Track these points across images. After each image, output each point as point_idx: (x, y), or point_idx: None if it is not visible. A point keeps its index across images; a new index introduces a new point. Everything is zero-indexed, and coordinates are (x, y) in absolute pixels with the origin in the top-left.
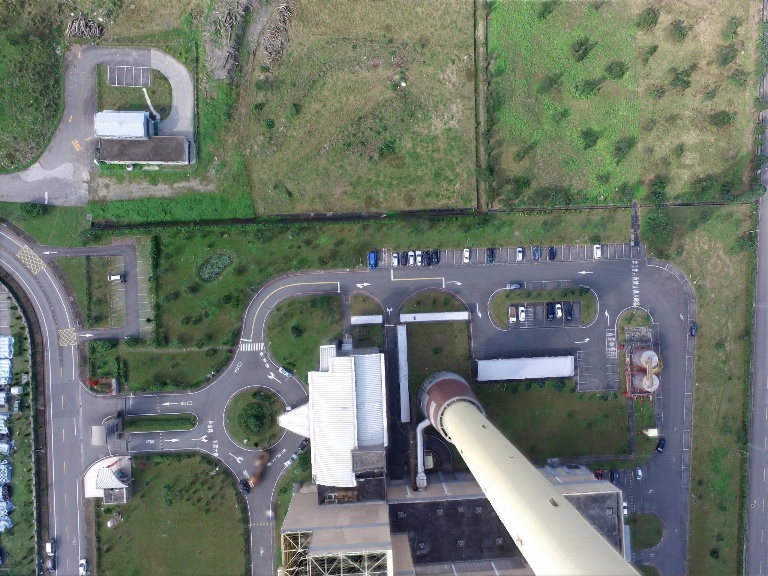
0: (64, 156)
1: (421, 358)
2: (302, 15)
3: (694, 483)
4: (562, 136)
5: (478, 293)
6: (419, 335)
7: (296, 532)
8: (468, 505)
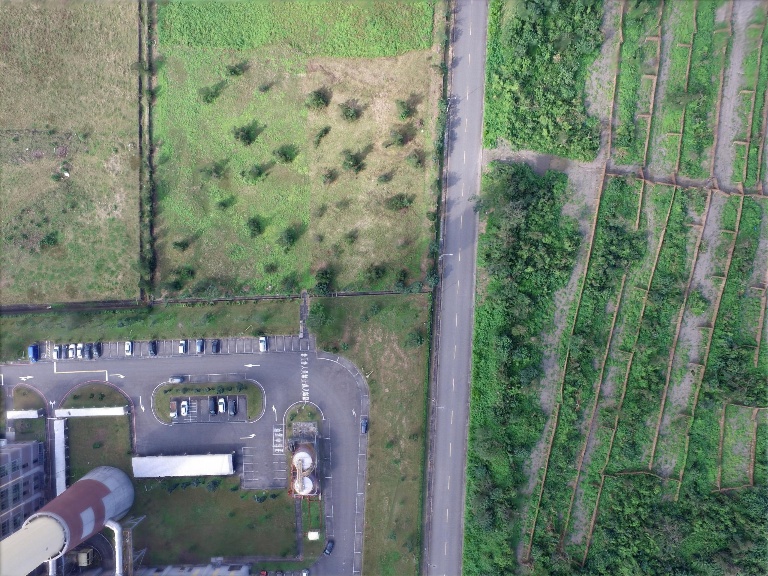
0: None
1: (83, 452)
2: None
3: None
4: (228, 224)
5: (141, 386)
6: (81, 429)
7: None
8: None
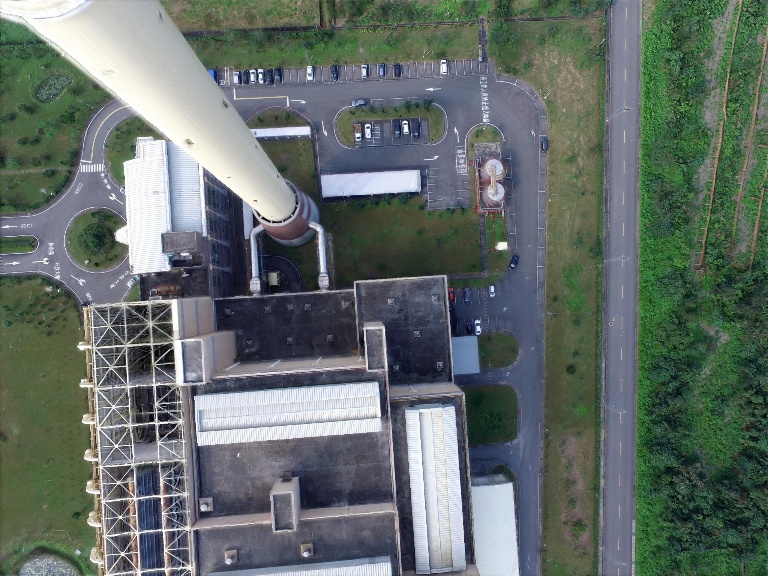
0: None
1: None
2: None
3: (549, 300)
4: None
5: (323, 111)
6: None
7: None
8: (298, 302)
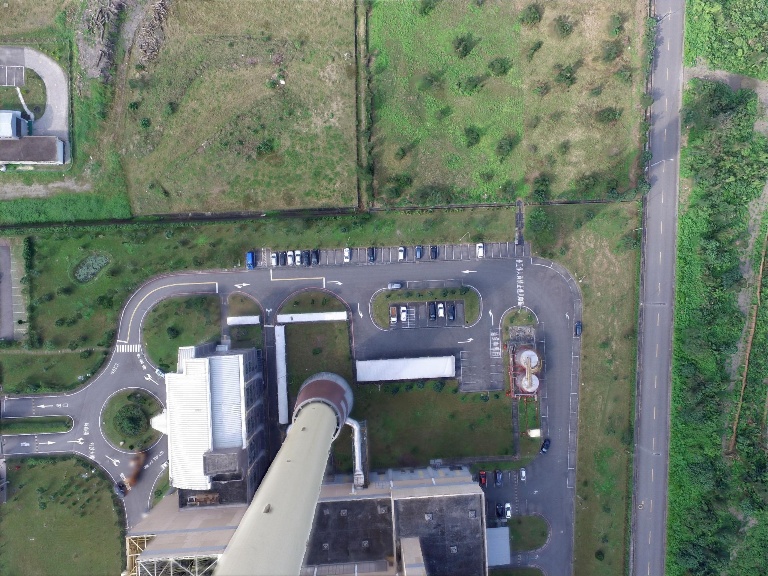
0: None
1: (301, 359)
2: (178, 13)
3: (580, 484)
4: (445, 134)
5: (359, 293)
6: (299, 336)
7: (142, 536)
8: (334, 507)
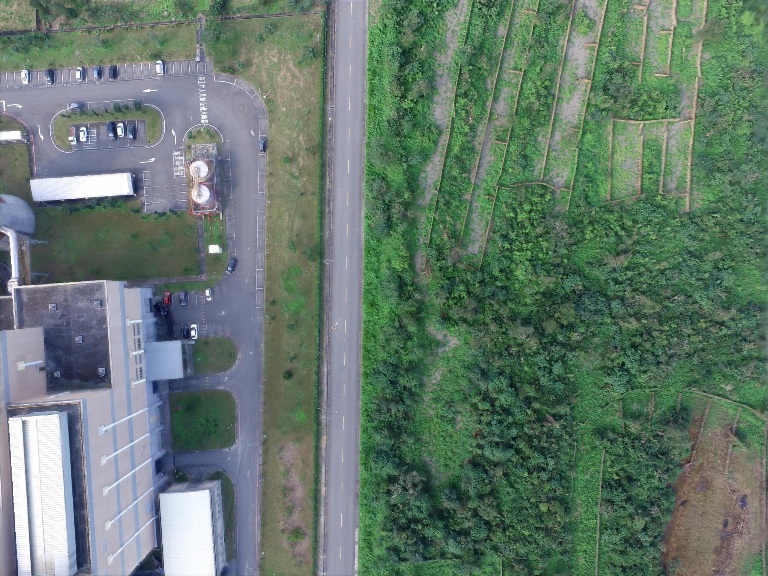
0: None
1: None
2: None
3: (268, 304)
4: None
5: (39, 115)
6: None
7: None
8: None
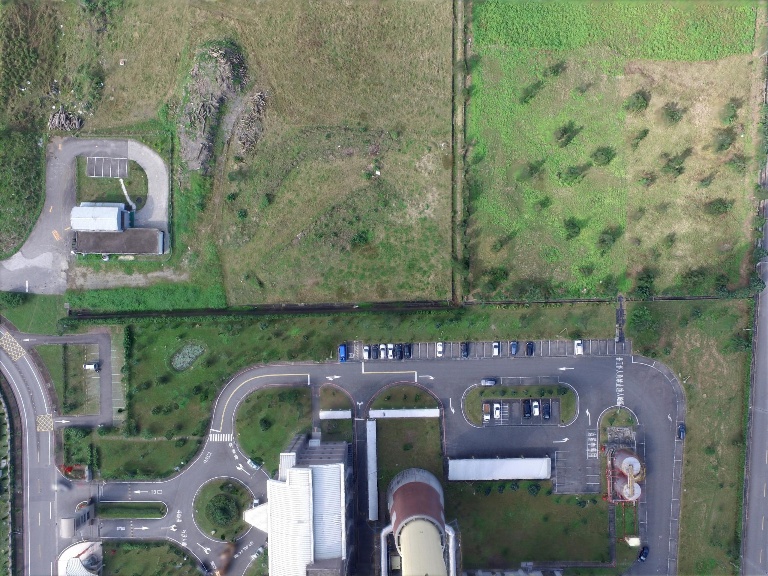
0: (44, 245)
1: (391, 454)
2: (276, 104)
3: None
4: (543, 226)
5: (451, 388)
6: (389, 430)
7: None
8: None
